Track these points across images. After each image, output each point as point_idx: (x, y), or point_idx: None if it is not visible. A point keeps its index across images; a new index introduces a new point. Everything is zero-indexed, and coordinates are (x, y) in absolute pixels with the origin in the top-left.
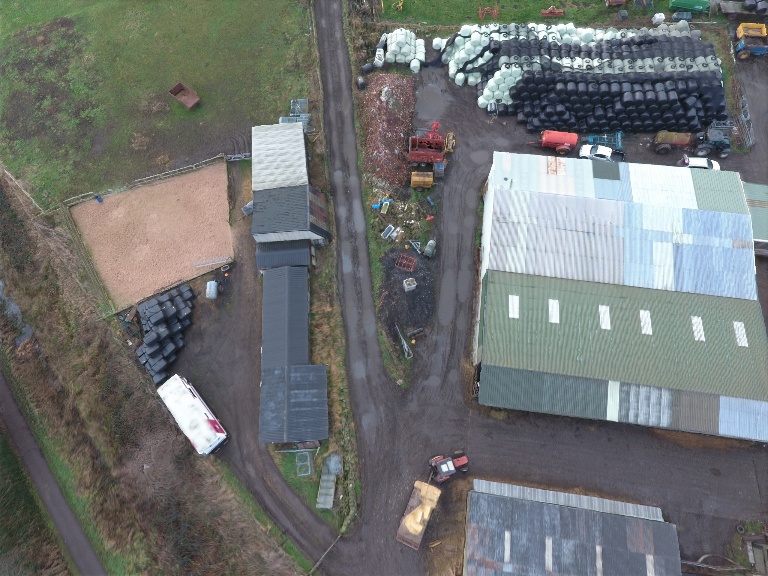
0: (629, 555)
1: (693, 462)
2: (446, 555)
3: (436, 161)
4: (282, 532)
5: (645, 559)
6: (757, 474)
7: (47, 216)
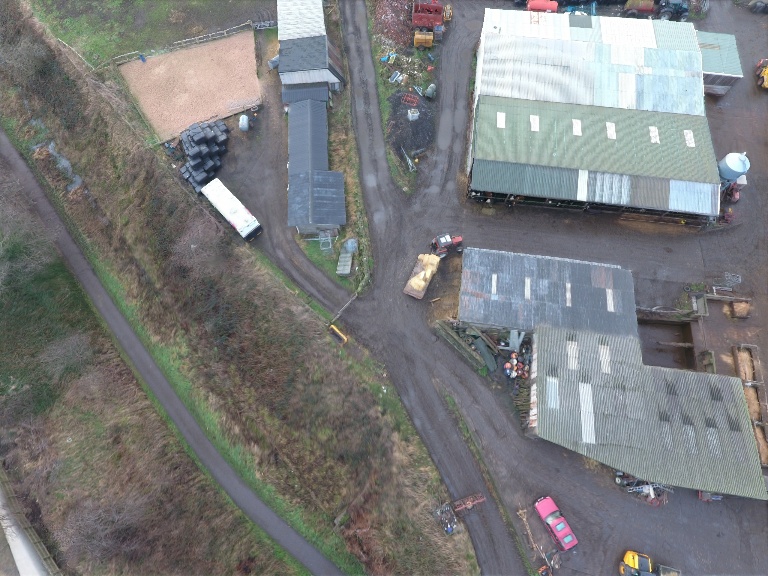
0: (593, 289)
1: (650, 243)
2: (444, 308)
3: (436, 25)
4: (308, 295)
5: (606, 292)
6: (702, 251)
7: (98, 73)
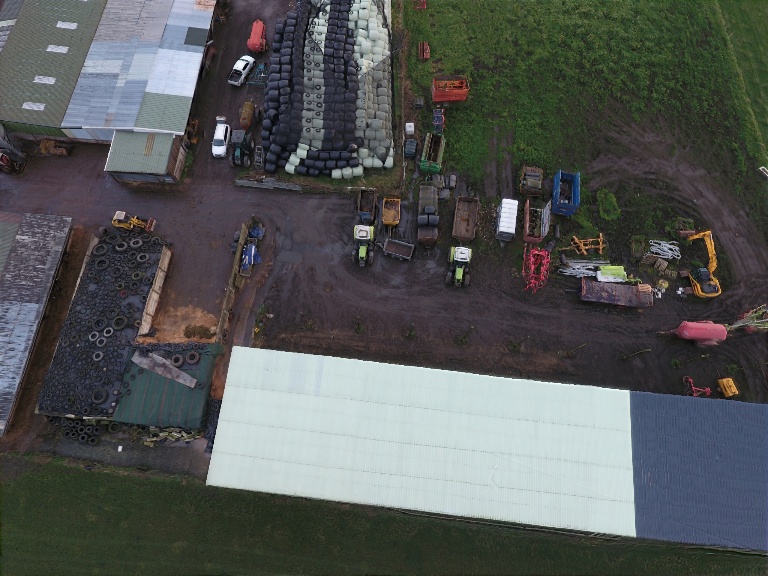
0: None
1: None
2: None
3: None
4: None
5: None
6: None
7: None
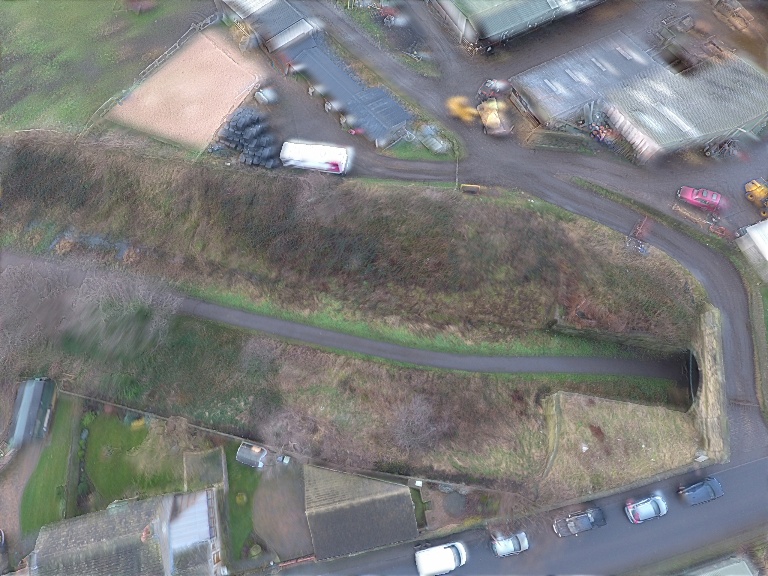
0: (609, 53)
1: (606, 19)
2: (521, 130)
3: None
4: (423, 182)
5: (617, 50)
6: (639, 6)
7: (85, 137)
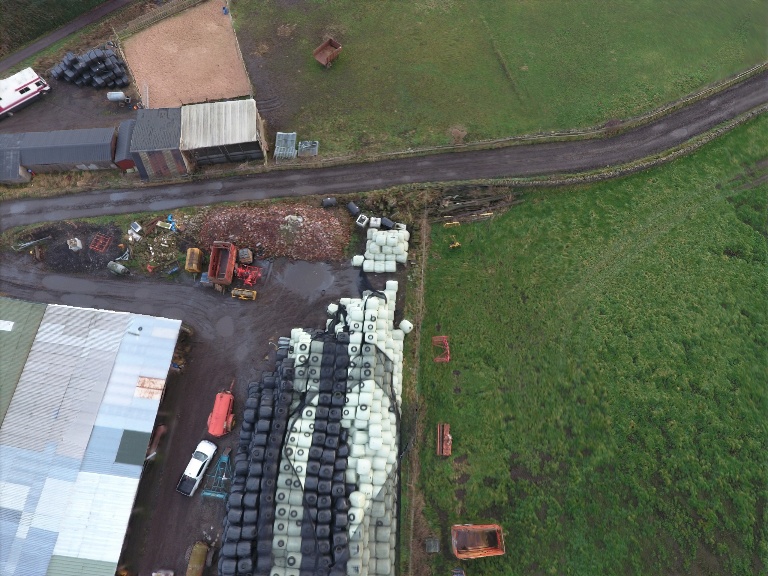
0: None
1: None
2: None
3: None
4: None
5: None
6: None
7: None
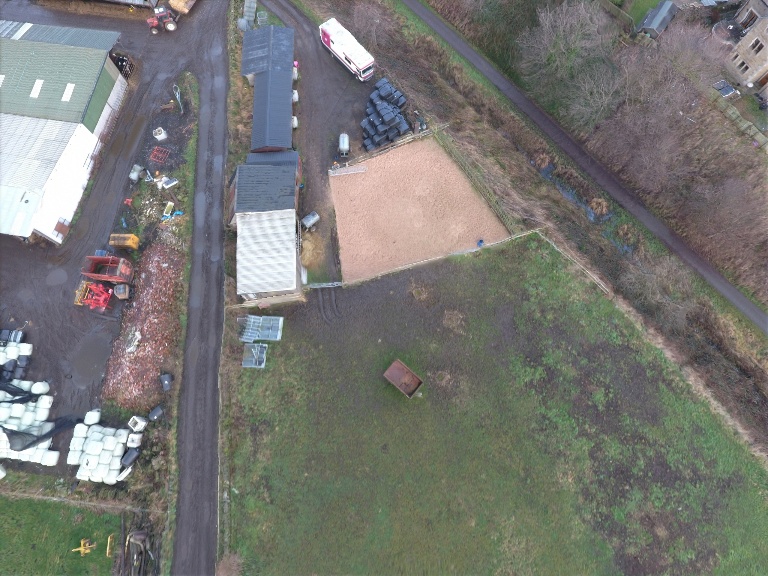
0: None
1: None
2: None
3: None
4: None
5: None
6: None
7: None
